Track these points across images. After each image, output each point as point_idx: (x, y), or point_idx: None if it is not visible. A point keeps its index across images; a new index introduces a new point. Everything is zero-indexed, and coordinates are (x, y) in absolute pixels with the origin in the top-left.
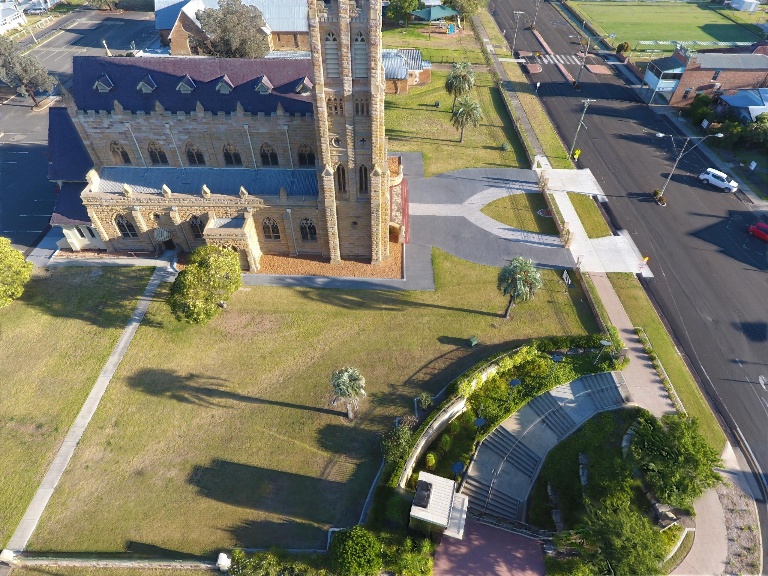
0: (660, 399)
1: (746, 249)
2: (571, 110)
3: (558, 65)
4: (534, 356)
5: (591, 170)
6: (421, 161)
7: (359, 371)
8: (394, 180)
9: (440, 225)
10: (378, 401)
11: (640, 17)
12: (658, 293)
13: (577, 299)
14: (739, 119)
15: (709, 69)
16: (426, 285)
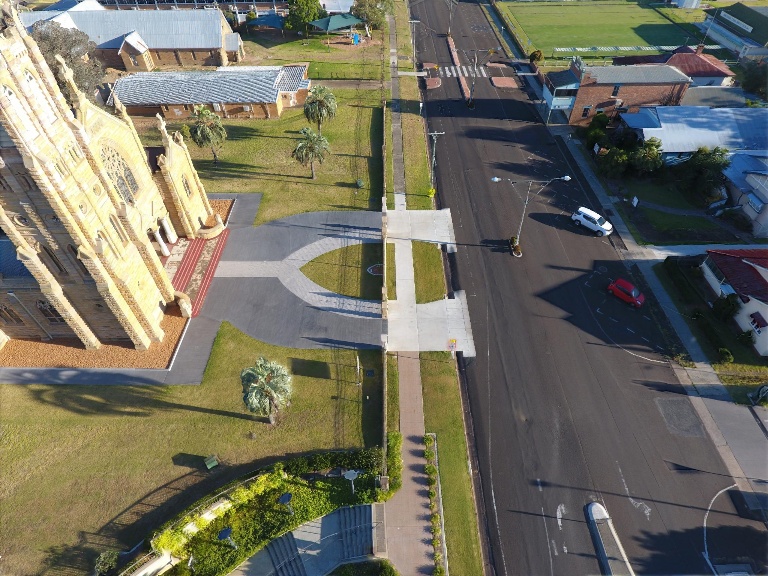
0: (420, 546)
1: (599, 314)
2: (455, 134)
3: (460, 79)
4: (282, 482)
5: (451, 210)
6: (257, 204)
7: (51, 511)
8: (207, 233)
9: (244, 290)
10: (53, 560)
11: (571, 19)
12: (473, 380)
13: (369, 392)
14: (635, 142)
15: (607, 84)
16: (192, 377)
